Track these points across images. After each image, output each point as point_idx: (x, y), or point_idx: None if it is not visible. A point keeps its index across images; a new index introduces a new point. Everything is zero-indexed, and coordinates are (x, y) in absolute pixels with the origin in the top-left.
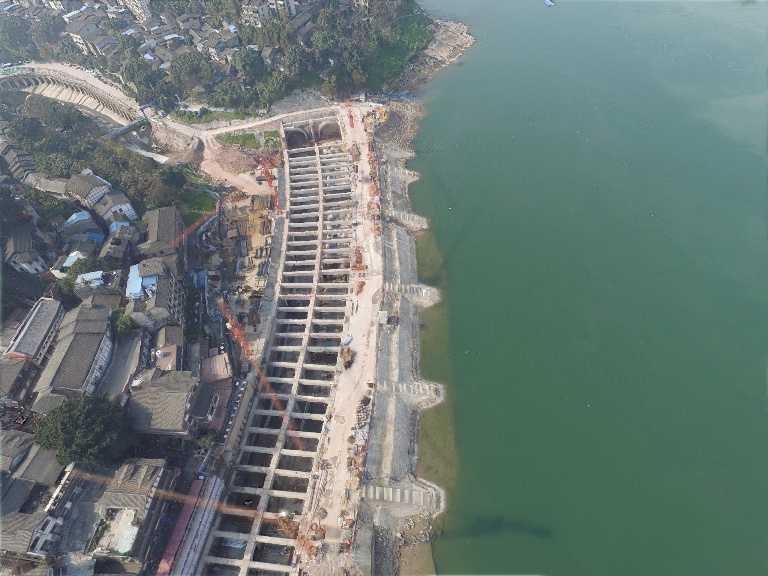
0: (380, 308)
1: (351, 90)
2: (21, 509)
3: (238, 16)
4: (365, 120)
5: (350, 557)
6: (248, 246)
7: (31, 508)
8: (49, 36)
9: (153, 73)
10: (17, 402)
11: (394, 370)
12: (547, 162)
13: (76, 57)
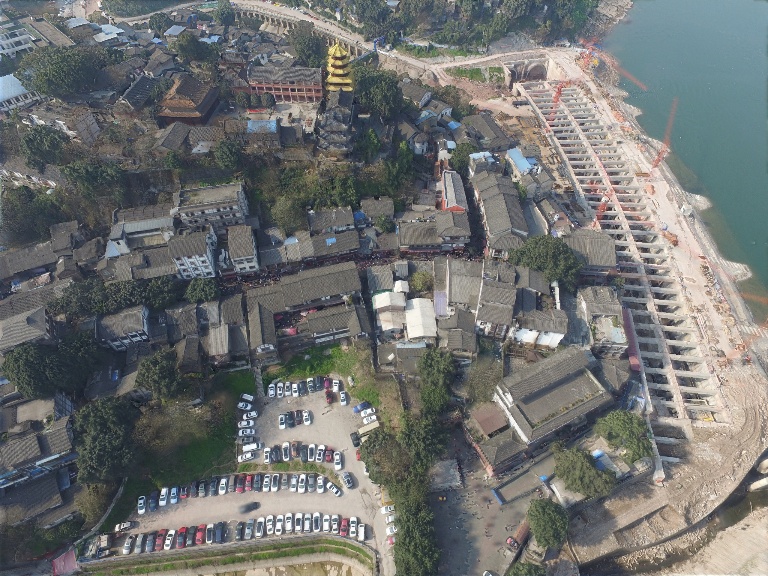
0: (678, 205)
1: (556, 36)
2: (537, 309)
3: None
4: (578, 62)
5: (754, 368)
6: None
7: None
8: None
9: (383, 9)
10: (464, 245)
11: (710, 250)
12: (751, 105)
13: None
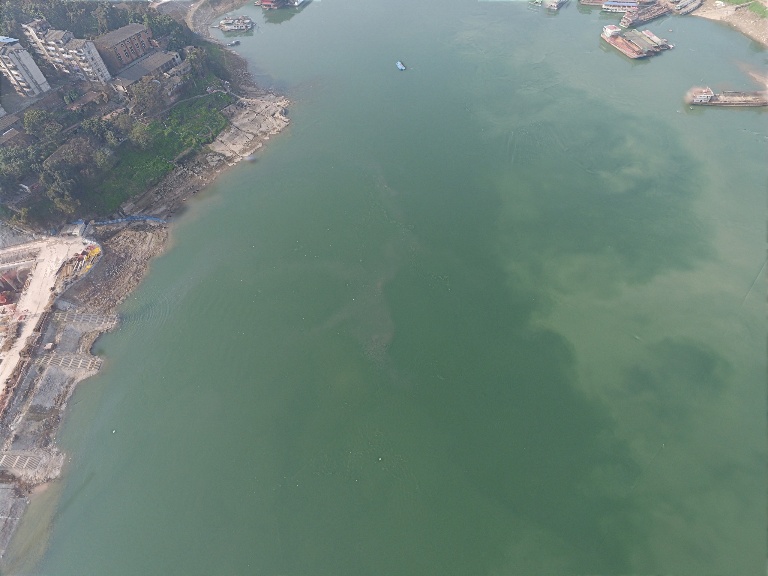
0: None
1: (65, 219)
2: None
3: None
4: (62, 270)
5: None
6: None
7: None
8: None
9: None
10: None
11: None
12: (282, 342)
13: None
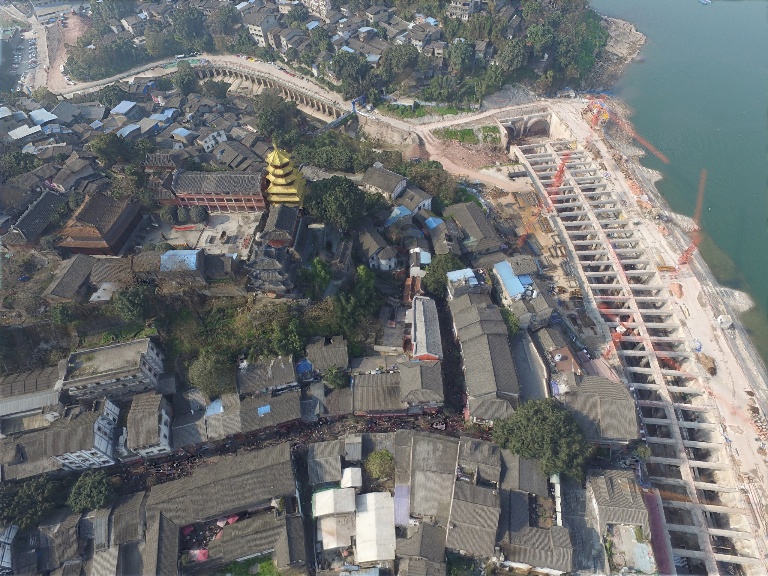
0: (713, 312)
1: (559, 86)
2: (530, 523)
3: (440, 8)
4: (585, 117)
5: None
6: (538, 245)
7: (534, 522)
8: (226, 27)
9: (362, 66)
10: (437, 406)
11: (758, 378)
12: None
13: (254, 49)
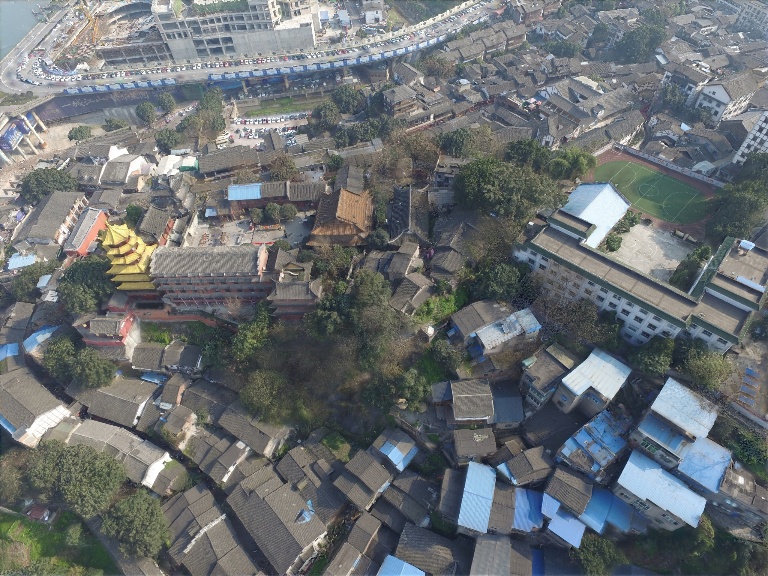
0: None
1: None
2: (83, 158)
3: None
4: None
5: None
6: None
7: None
8: None
9: None
10: None
11: None
12: None
13: None
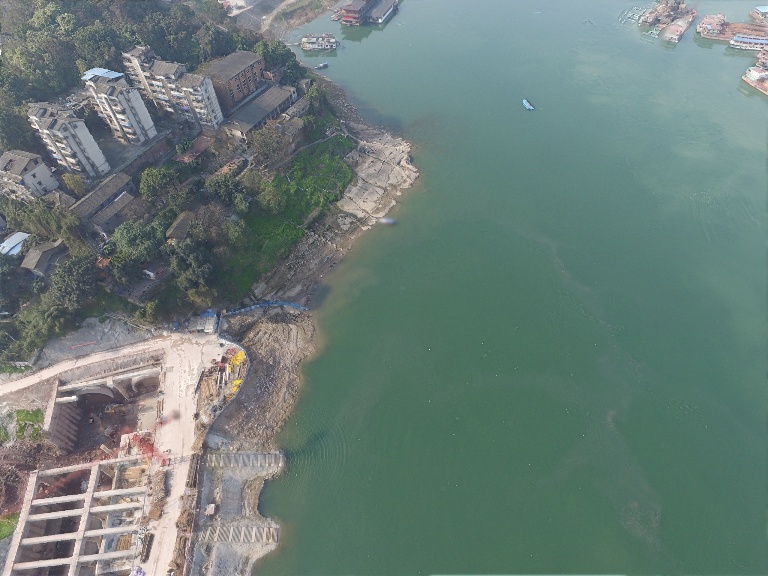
0: None
1: (192, 310)
2: None
3: None
4: (202, 386)
5: None
6: None
7: None
8: None
9: None
10: None
11: None
12: (513, 502)
13: None
